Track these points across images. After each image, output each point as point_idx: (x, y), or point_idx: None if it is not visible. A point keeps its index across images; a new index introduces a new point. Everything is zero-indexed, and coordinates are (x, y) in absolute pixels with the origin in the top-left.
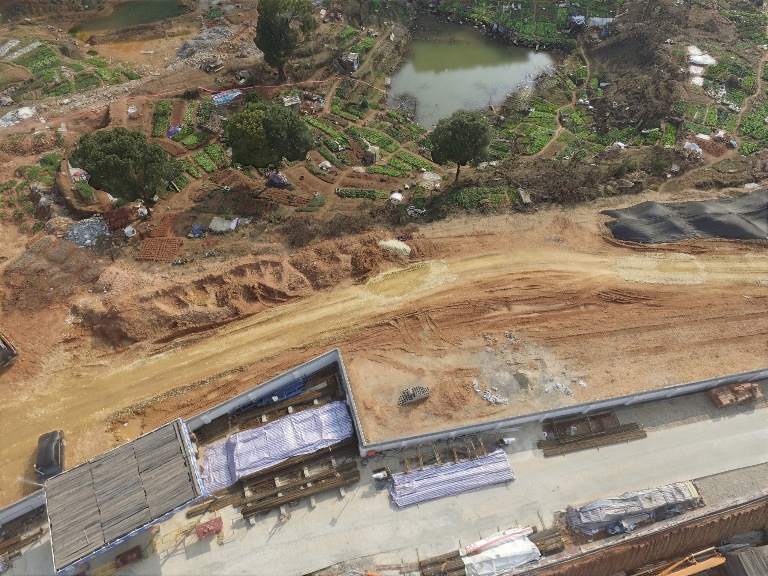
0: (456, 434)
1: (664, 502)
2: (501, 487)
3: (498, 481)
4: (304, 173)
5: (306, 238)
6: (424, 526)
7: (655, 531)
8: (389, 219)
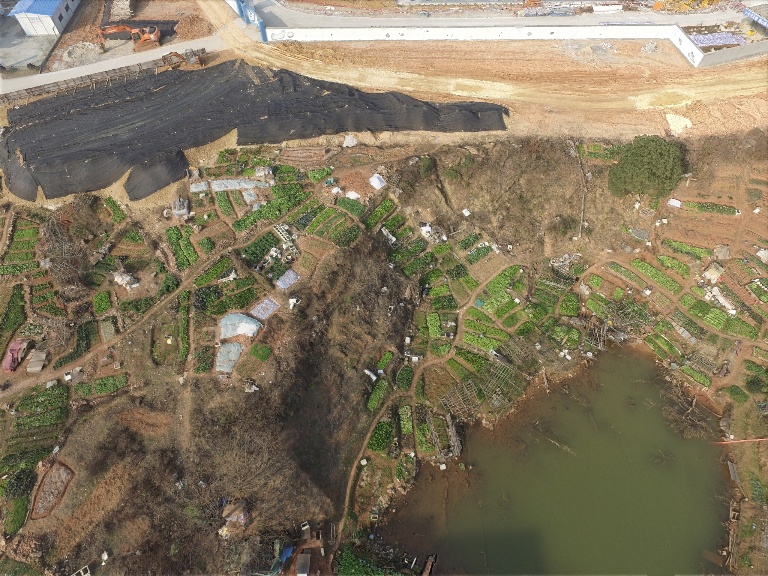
0: None
1: None
2: None
3: None
4: None
5: None
6: (638, 18)
7: None
8: None
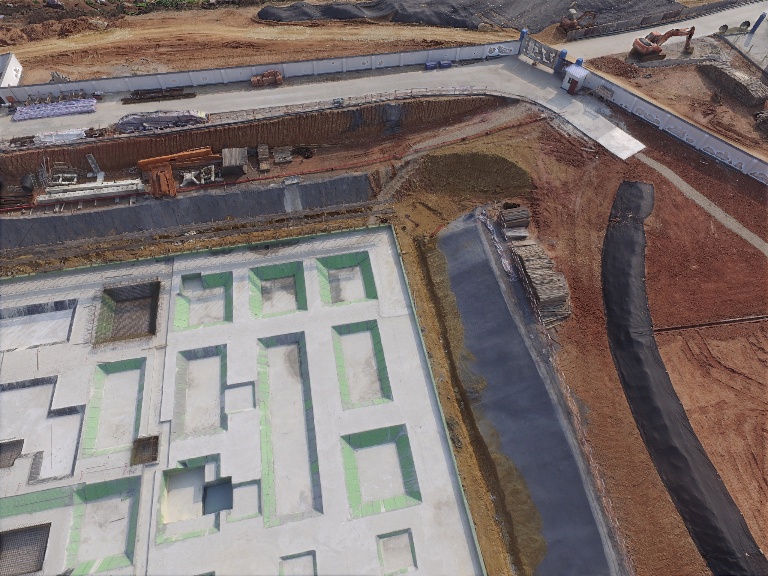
0: (67, 90)
1: (175, 115)
2: (84, 114)
3: (83, 111)
4: (80, 3)
5: (40, 19)
6: (25, 127)
7: (168, 132)
8: (111, 14)
